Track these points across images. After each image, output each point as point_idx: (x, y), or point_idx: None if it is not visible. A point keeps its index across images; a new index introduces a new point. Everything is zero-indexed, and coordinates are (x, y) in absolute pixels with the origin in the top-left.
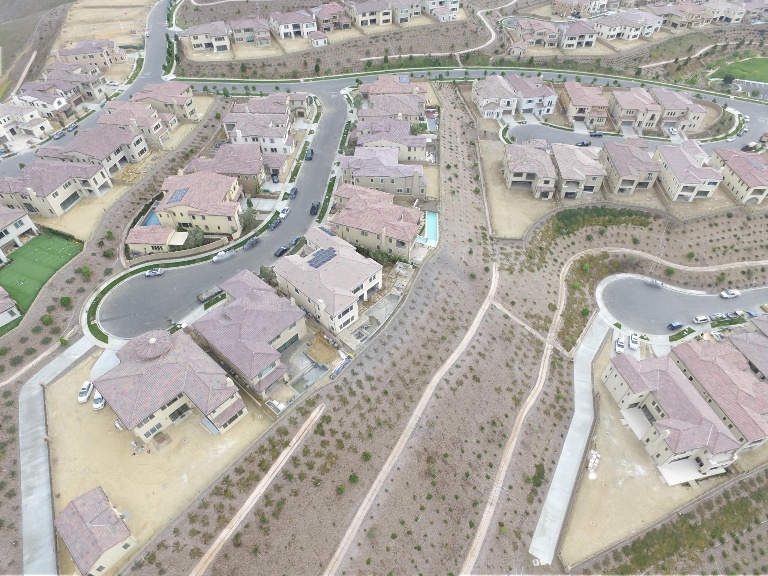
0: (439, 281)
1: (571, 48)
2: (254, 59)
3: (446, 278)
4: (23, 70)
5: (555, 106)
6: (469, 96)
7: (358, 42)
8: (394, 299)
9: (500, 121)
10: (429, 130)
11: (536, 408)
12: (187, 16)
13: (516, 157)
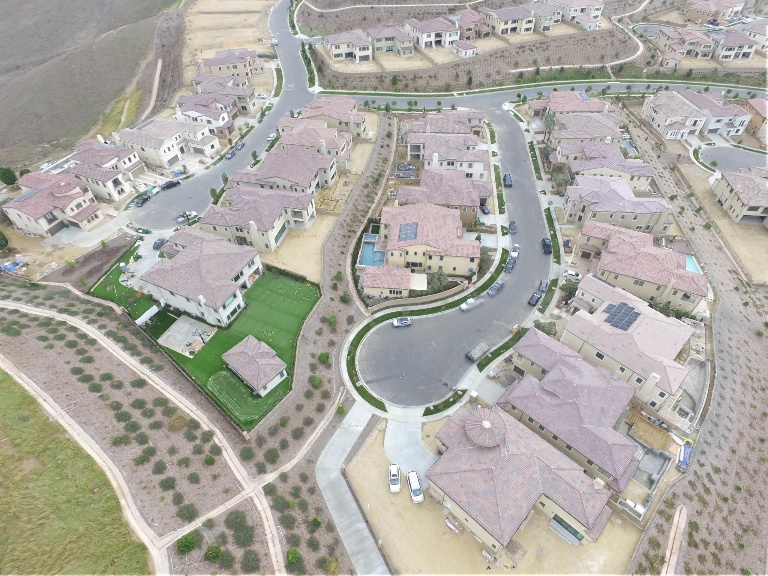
0: (733, 342)
1: (727, 59)
2: (404, 71)
3: (737, 337)
4: (154, 79)
5: (746, 126)
6: (636, 113)
7: (505, 52)
8: (694, 364)
9: (685, 142)
10: (631, 154)
11: None
12: (311, 23)
13: (746, 188)
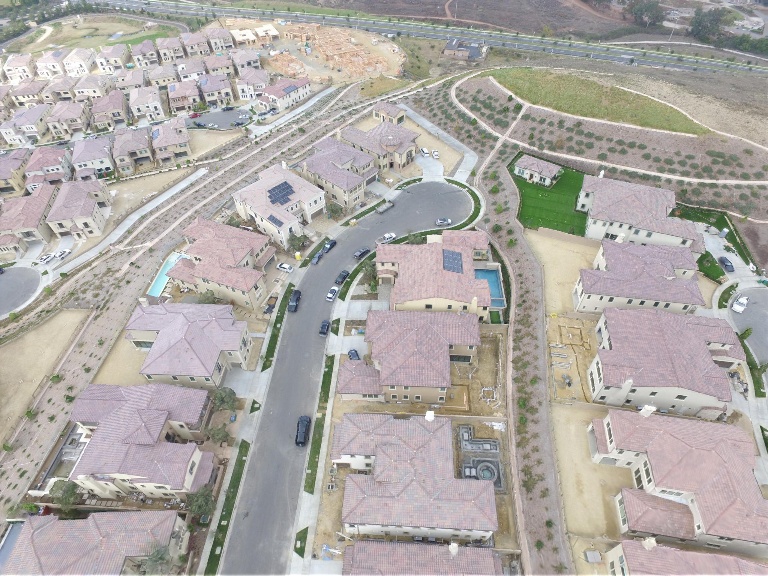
0: None
1: None
2: None
3: None
4: None
5: None
6: None
7: None
8: None
9: None
10: None
11: None
12: None
13: None
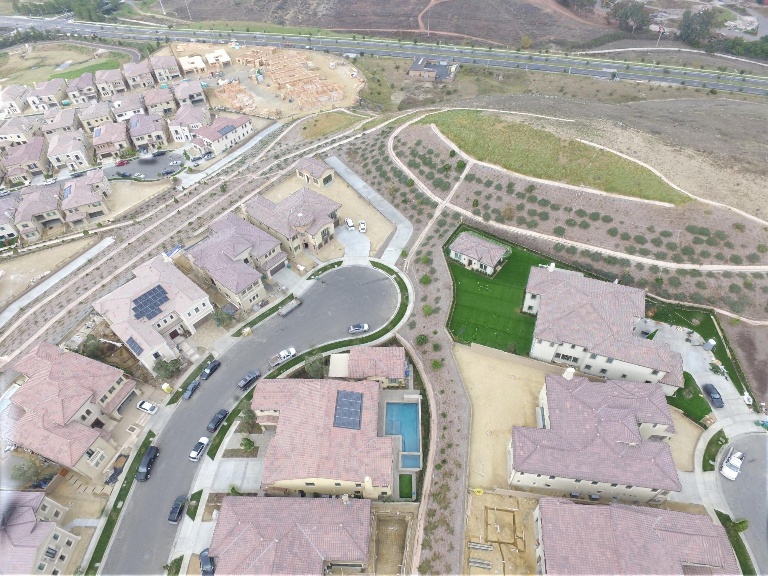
0: None
1: None
2: None
3: None
4: None
5: None
6: None
7: None
8: None
9: None
10: None
11: (48, 295)
12: None
13: None
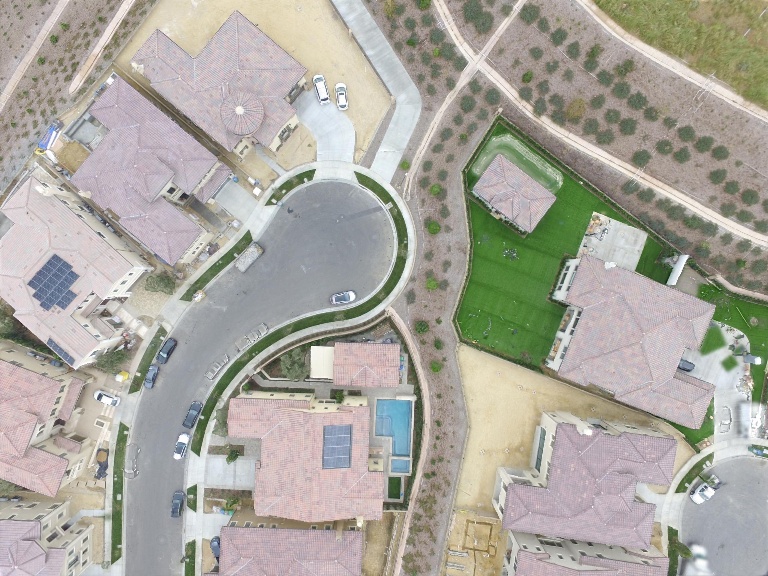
0: None
1: None
2: None
3: None
4: None
5: None
6: None
7: None
8: None
9: None
10: None
11: None
12: None
13: None
